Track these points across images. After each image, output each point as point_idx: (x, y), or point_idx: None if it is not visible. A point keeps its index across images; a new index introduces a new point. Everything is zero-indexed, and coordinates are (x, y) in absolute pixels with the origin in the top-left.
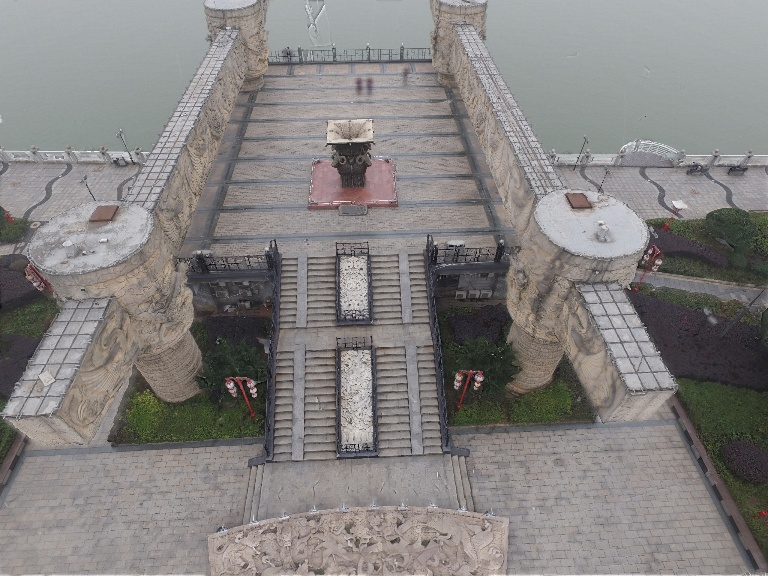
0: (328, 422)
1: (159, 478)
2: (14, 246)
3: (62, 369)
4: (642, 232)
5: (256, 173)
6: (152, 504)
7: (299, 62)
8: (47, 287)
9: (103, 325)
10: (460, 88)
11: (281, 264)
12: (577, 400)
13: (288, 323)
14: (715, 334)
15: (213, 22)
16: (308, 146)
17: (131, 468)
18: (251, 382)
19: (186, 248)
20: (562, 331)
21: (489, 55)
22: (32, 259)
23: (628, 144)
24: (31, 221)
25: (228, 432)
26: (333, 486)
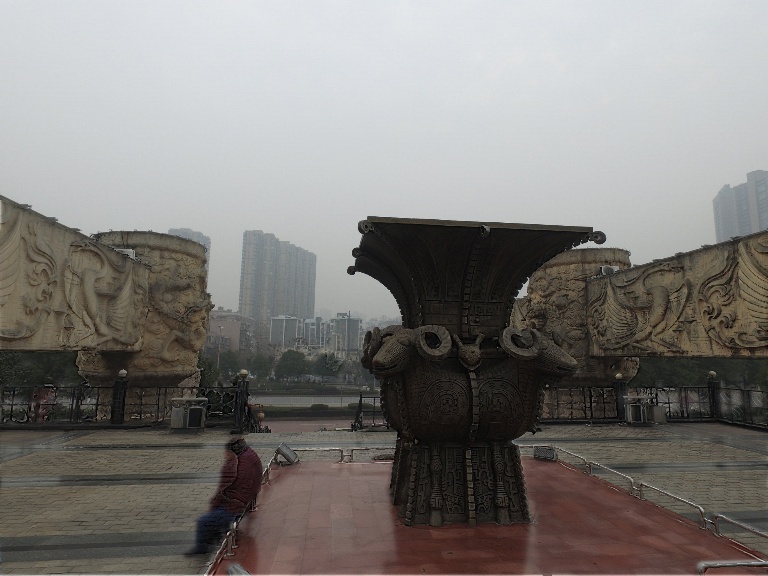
0: None
1: None
2: None
3: None
4: None
5: None
6: None
7: None
8: None
9: None
10: None
11: None
12: None
13: None
14: None
15: None
16: None
17: None
18: None
19: (720, 433)
20: None
21: None
22: None
23: None
24: None
25: None
26: None
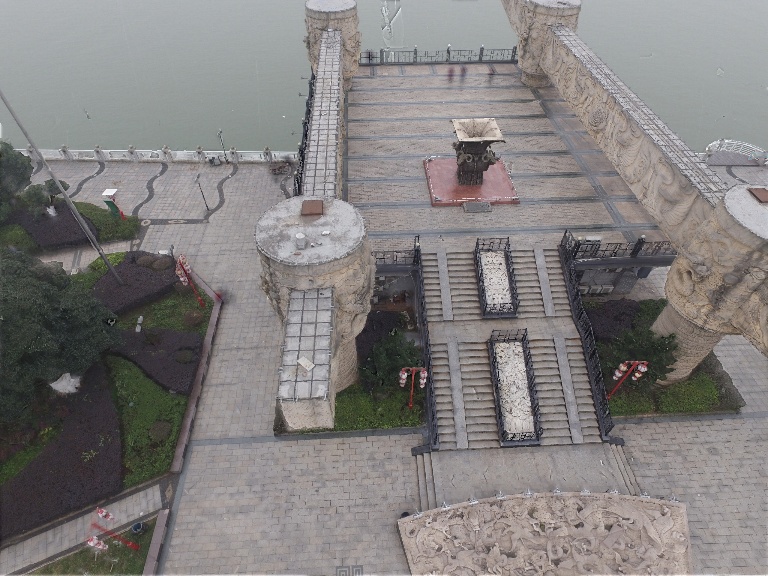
0: (487, 412)
1: (328, 466)
2: (130, 243)
3: (316, 355)
4: None
5: (371, 171)
6: (328, 491)
7: (380, 63)
8: (189, 282)
9: (334, 314)
10: (560, 88)
11: (421, 259)
12: (722, 391)
13: (435, 316)
14: None
15: (315, 24)
16: (414, 145)
17: (299, 457)
18: (425, 372)
19: None
20: (747, 321)
21: None
22: (265, 251)
23: (713, 143)
24: (141, 219)
25: (390, 422)
26: (503, 473)
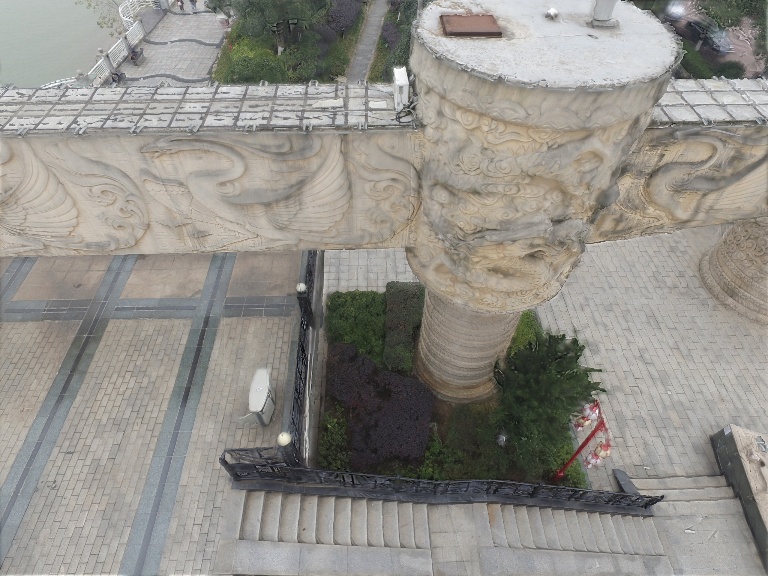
0: None
1: None
2: None
3: None
4: None
5: None
6: None
7: None
8: None
9: None
10: None
11: None
12: None
13: None
14: None
15: None
16: None
17: None
18: None
19: None
20: None
21: None
22: None
23: None
24: None
25: None
26: None
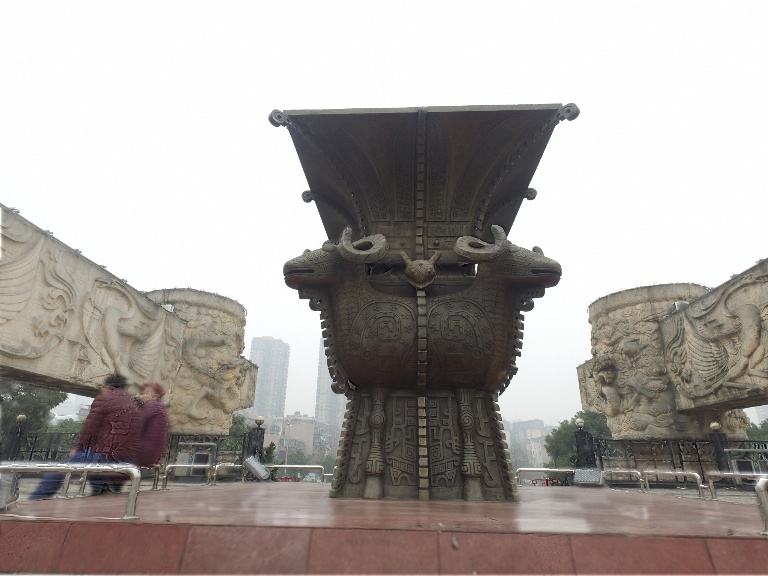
0: None
1: None
2: None
3: None
4: None
5: None
6: None
7: None
8: None
9: None
10: None
11: None
12: None
13: None
14: None
15: None
16: None
17: None
18: None
19: None
20: None
21: None
22: None
23: None
24: None
25: None
26: None
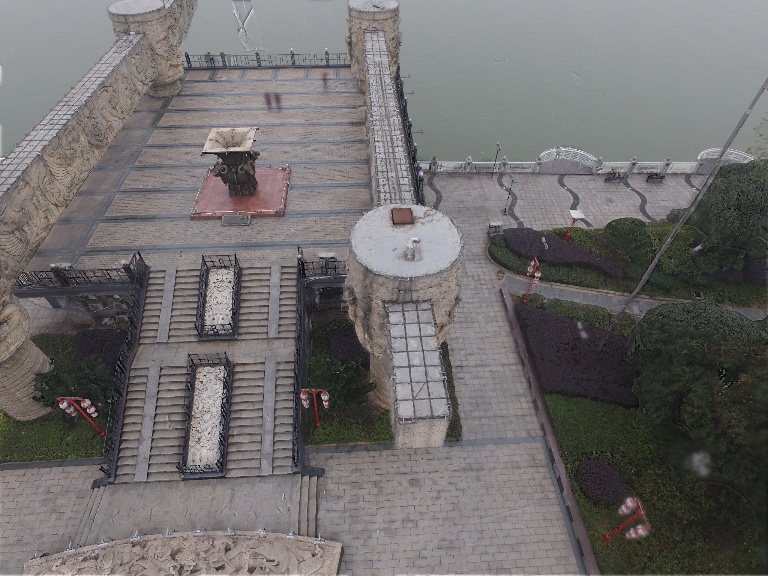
0: (177, 441)
1: None
2: None
3: None
4: (455, 250)
5: (148, 182)
6: None
7: (223, 67)
8: None
9: None
10: None
11: (148, 277)
12: None
13: (149, 338)
14: (594, 348)
15: (117, 27)
16: (209, 154)
17: None
18: (85, 402)
19: (54, 260)
20: None
21: (388, 62)
22: None
23: (548, 151)
24: None
25: (73, 452)
26: (172, 509)
